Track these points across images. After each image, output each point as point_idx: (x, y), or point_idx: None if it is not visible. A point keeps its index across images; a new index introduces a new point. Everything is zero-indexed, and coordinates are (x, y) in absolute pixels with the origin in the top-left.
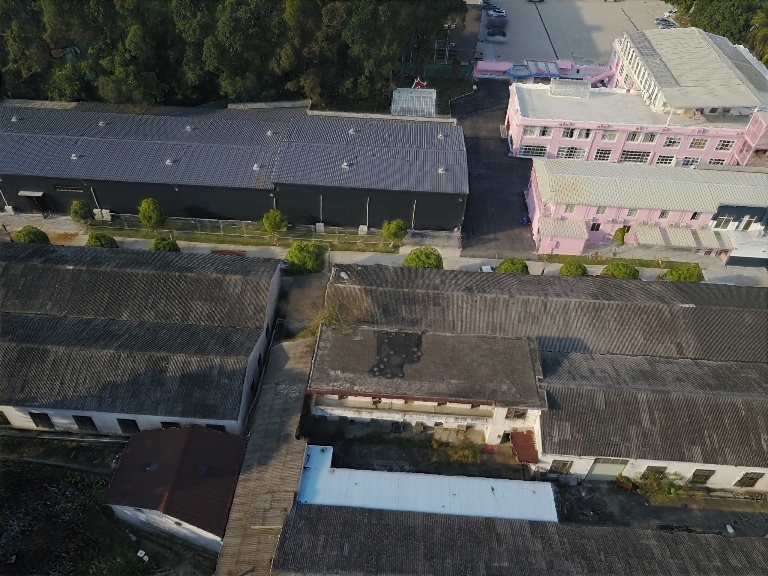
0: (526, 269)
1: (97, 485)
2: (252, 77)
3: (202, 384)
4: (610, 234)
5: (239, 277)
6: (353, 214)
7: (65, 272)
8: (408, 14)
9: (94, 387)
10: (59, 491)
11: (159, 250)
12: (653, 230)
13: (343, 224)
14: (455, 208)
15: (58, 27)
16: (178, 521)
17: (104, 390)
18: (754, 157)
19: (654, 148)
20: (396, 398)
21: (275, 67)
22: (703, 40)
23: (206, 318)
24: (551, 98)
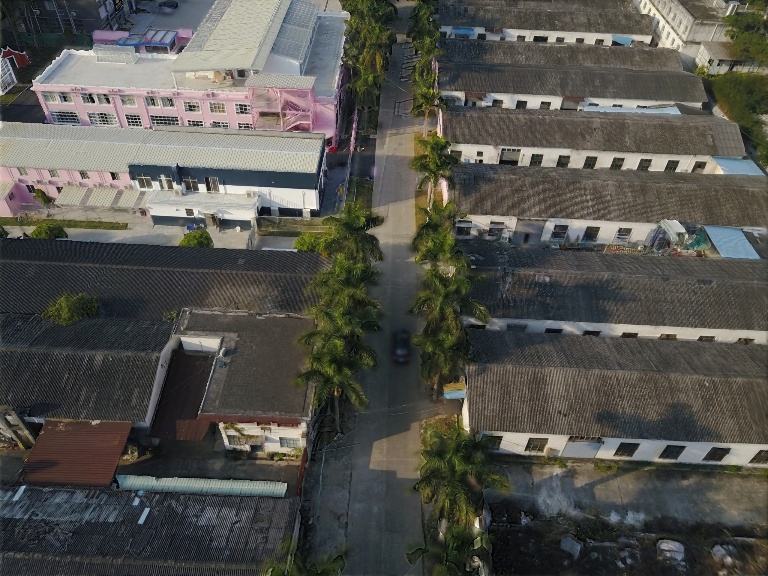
0: None
1: None
2: None
3: None
4: (48, 196)
5: None
6: None
7: None
8: None
9: None
10: None
11: None
12: (79, 191)
13: None
14: None
15: None
16: None
17: None
18: (272, 120)
19: (178, 113)
20: None
21: None
22: (276, 6)
23: None
24: (94, 64)
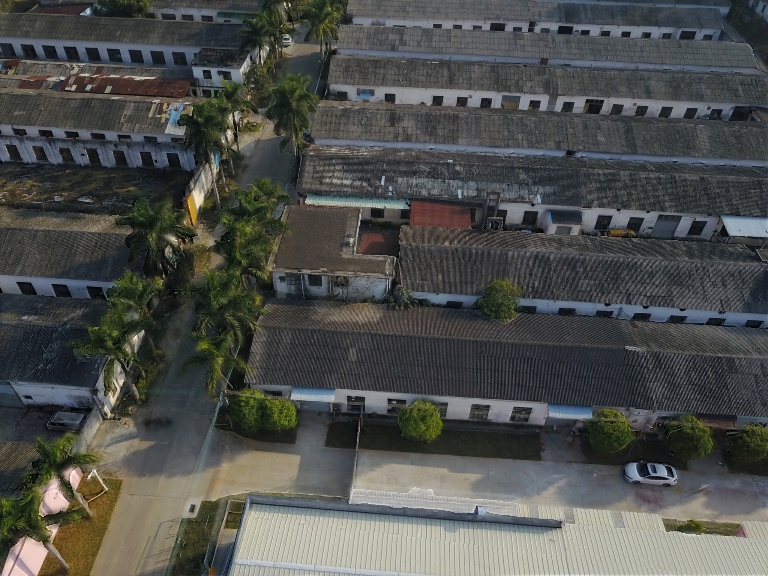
0: None
1: None
2: None
3: None
4: None
5: None
6: None
7: None
8: None
9: None
10: None
11: None
12: None
13: None
14: None
15: None
16: None
17: None
18: None
19: None
20: None
21: None
22: None
23: None
24: None
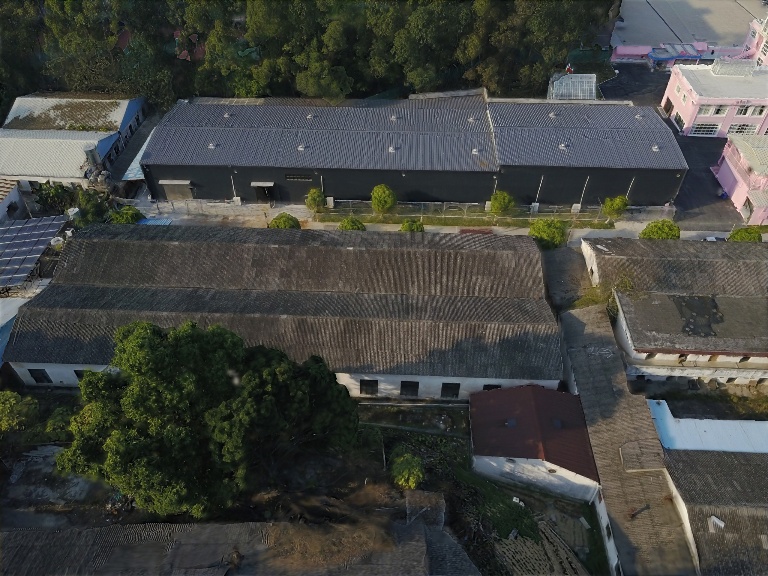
0: (761, 238)
1: (442, 443)
2: (432, 68)
3: (521, 348)
4: None
5: (510, 252)
6: (569, 193)
7: (347, 253)
8: (584, 1)
9: (423, 354)
10: (415, 448)
11: (414, 231)
12: None
13: (557, 203)
14: (671, 184)
15: (263, 26)
16: (554, 468)
17: (433, 356)
18: None
19: None
20: (718, 354)
21: (460, 57)
22: None
23: (490, 290)
24: (716, 78)
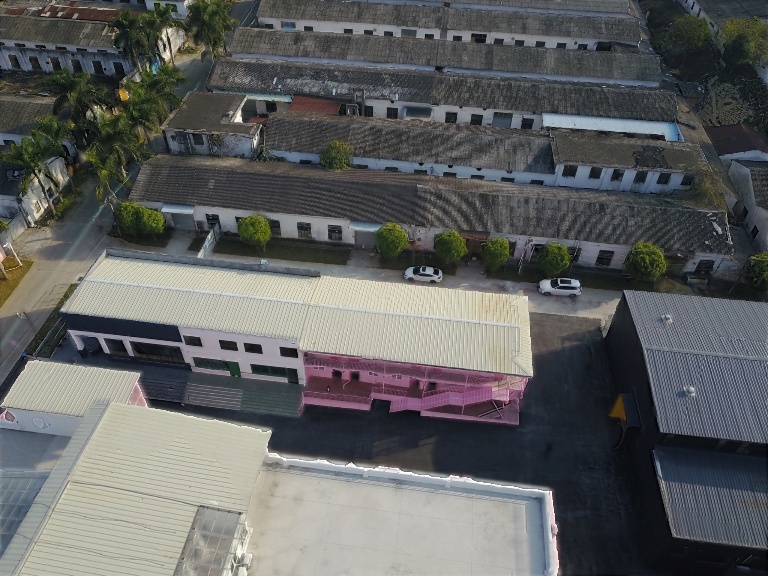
0: None
1: None
2: None
3: None
4: None
5: None
6: None
7: None
8: None
9: None
10: None
11: None
12: None
13: None
14: None
15: None
16: None
17: None
18: None
19: None
20: None
21: None
22: None
23: None
24: None
